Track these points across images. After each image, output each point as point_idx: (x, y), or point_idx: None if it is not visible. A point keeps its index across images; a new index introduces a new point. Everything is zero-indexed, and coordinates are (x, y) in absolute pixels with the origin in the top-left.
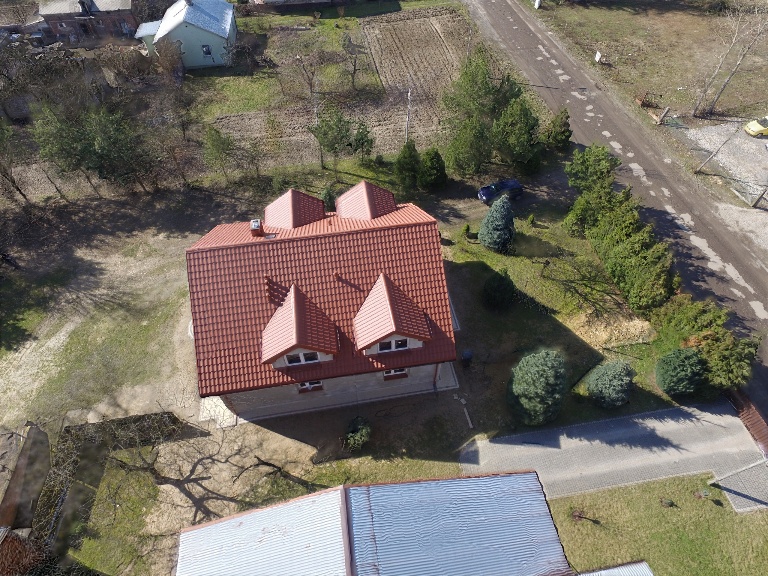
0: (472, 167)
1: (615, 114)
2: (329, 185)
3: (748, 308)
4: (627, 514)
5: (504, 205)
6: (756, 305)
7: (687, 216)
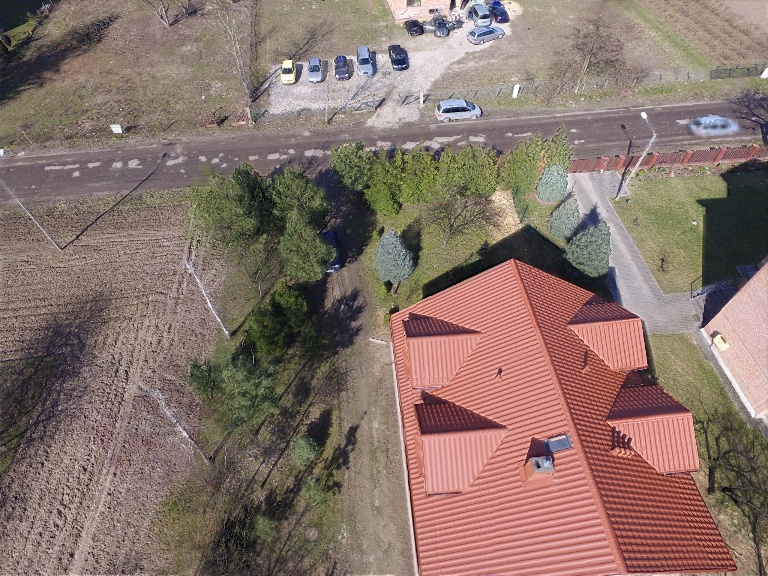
0: (334, 250)
1: (223, 145)
2: (258, 450)
3: (475, 143)
4: (651, 243)
5: (397, 236)
6: (473, 139)
7: (380, 143)
